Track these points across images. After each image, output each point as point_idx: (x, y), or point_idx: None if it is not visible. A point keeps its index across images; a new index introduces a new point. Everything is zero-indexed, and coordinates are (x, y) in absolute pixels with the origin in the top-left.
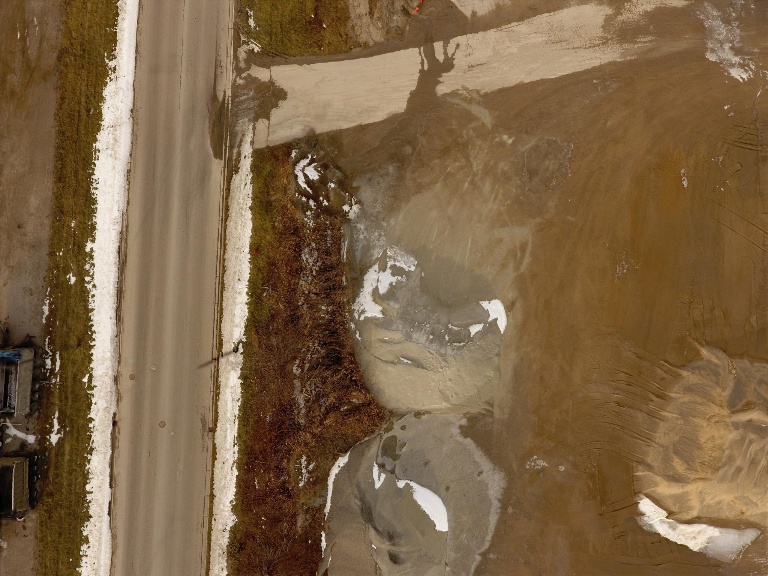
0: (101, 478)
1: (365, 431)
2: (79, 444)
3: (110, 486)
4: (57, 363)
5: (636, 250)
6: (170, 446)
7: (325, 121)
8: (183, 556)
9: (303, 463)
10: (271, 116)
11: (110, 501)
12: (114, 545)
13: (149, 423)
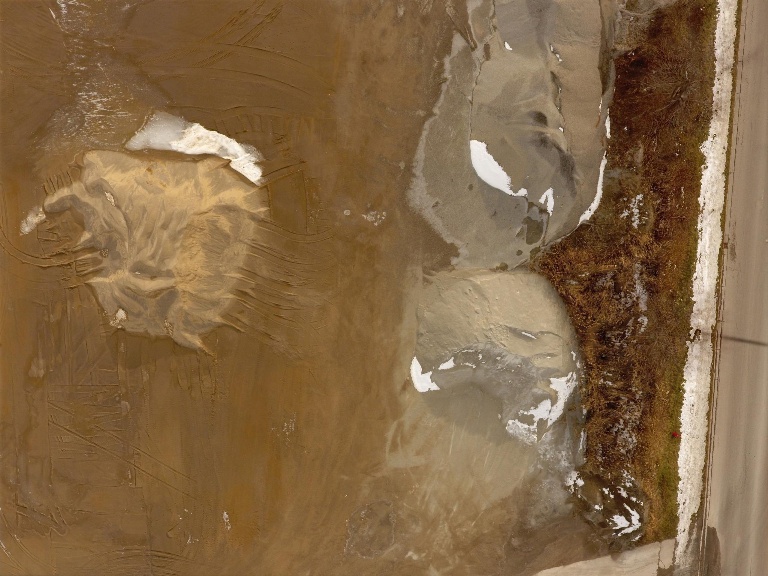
0: None
1: (562, 249)
2: None
3: None
4: None
5: (275, 447)
6: None
7: (601, 568)
8: (759, 106)
9: (636, 219)
10: (656, 572)
11: None
12: None
13: None
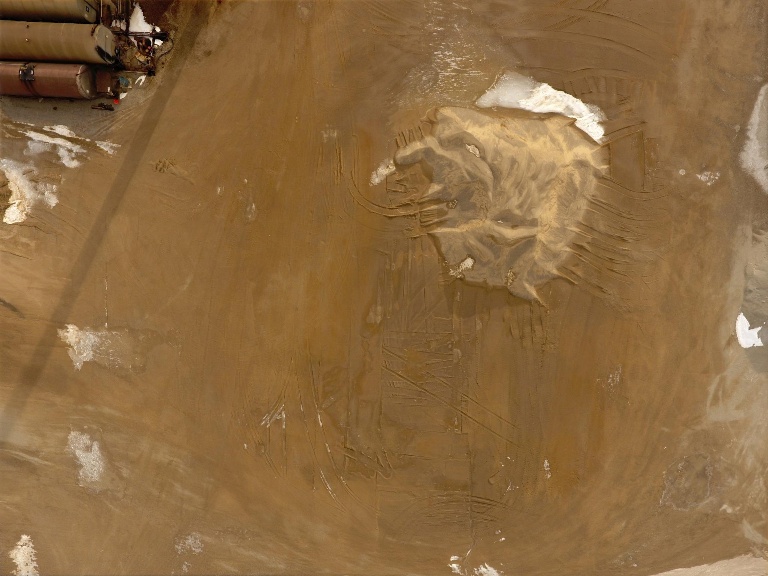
0: None
1: None
2: None
3: None
4: None
5: (599, 397)
6: None
7: None
8: None
9: None
10: None
11: None
12: None
13: None
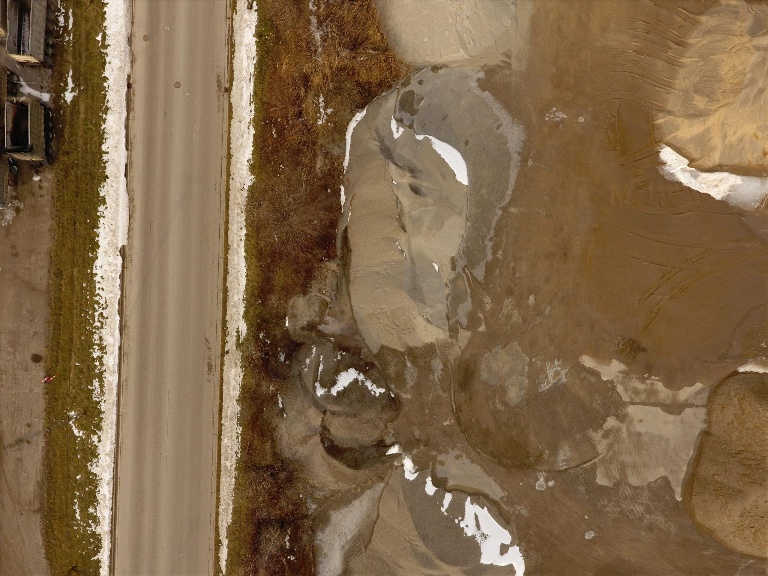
0: (117, 138)
1: (382, 84)
2: (94, 103)
3: (126, 148)
4: (70, 21)
5: None
6: (186, 107)
7: None
8: (201, 218)
9: (321, 103)
10: None
11: (126, 164)
12: (131, 208)
13: (164, 84)
